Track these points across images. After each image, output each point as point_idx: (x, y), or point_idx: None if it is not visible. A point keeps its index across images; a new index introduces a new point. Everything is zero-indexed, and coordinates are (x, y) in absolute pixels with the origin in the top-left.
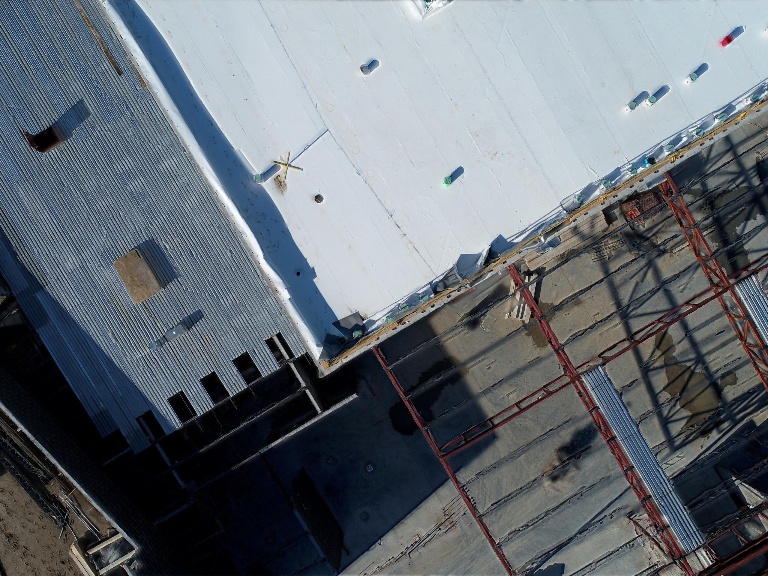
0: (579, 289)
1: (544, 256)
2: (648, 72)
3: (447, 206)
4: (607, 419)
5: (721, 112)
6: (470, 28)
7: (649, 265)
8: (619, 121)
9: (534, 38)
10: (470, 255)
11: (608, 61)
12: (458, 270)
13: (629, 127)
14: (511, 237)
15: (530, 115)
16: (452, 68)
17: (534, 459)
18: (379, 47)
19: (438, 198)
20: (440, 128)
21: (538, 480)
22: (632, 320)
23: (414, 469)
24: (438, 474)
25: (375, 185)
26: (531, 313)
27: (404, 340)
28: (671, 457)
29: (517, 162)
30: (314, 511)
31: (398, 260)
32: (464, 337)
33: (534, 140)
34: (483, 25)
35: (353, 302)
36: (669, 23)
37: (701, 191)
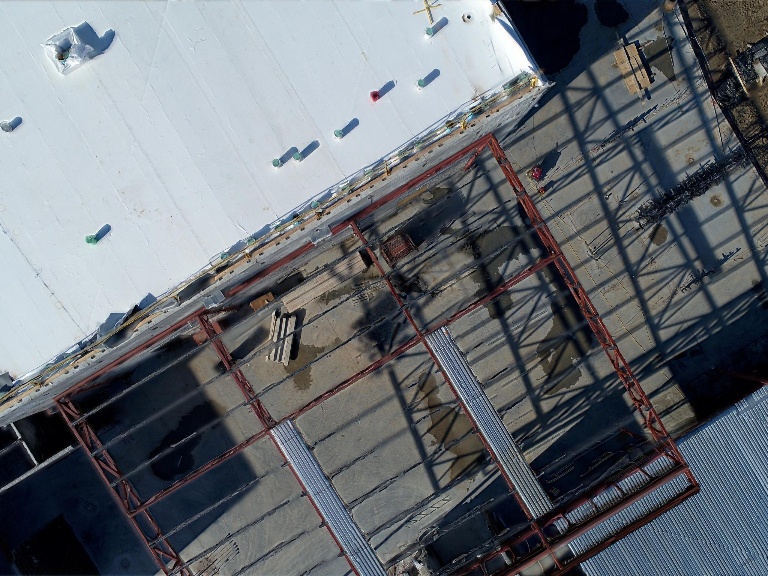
0: (340, 331)
1: (302, 298)
2: (297, 128)
3: (95, 264)
4: (299, 474)
5: (372, 168)
6: (113, 84)
7: (411, 306)
8: (268, 177)
9: (179, 94)
10: (119, 314)
11: (256, 117)
12: (100, 330)
13: (278, 183)
14: (161, 295)
15: (177, 172)
16: (96, 125)
17: (297, 503)
18: (22, 104)
19: (85, 256)
20: (86, 185)
21: (231, 537)
22: (395, 362)
23: (175, 515)
24: (200, 520)
25: (21, 243)
26: (290, 356)
27: (163, 384)
28: (437, 500)
29: (165, 219)
30: (54, 562)
31: (47, 319)
32: (224, 380)
33: (181, 197)
34: (126, 81)
35: (2, 362)
36: (317, 78)
37: (462, 231)
